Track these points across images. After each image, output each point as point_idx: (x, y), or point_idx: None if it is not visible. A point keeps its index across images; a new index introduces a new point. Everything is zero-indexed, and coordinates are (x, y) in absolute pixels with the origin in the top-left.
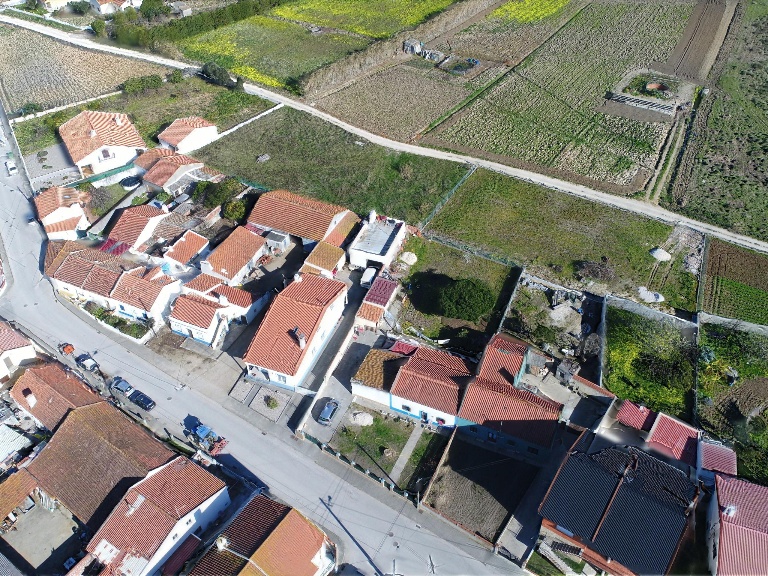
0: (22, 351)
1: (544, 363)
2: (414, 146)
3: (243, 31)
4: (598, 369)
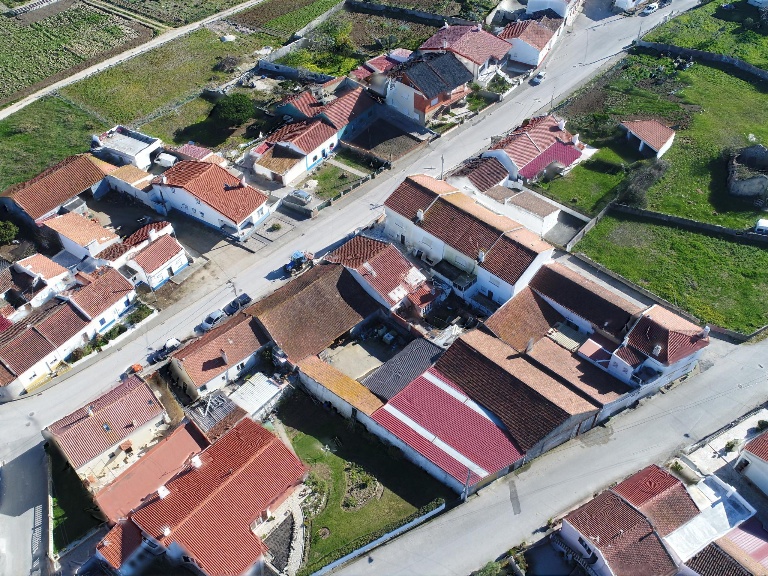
0: None
1: None
2: None
3: None
4: (318, 81)
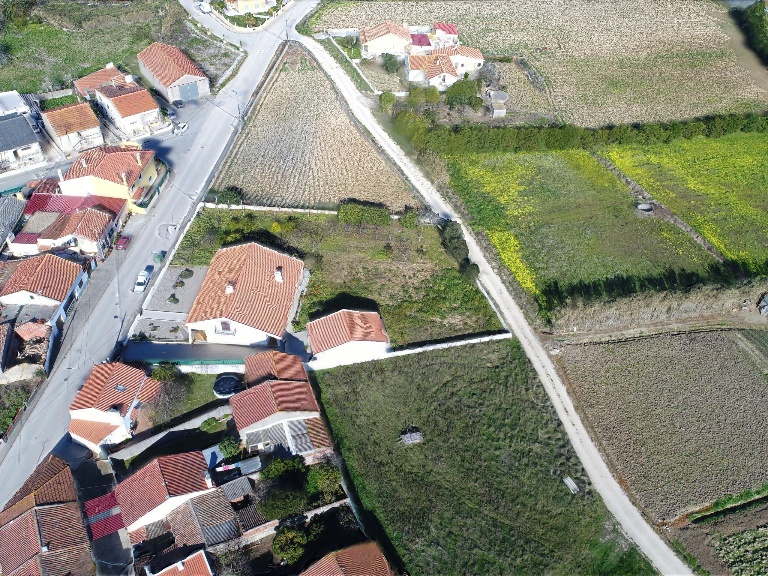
0: None
1: None
2: (661, 541)
3: (547, 169)
4: None
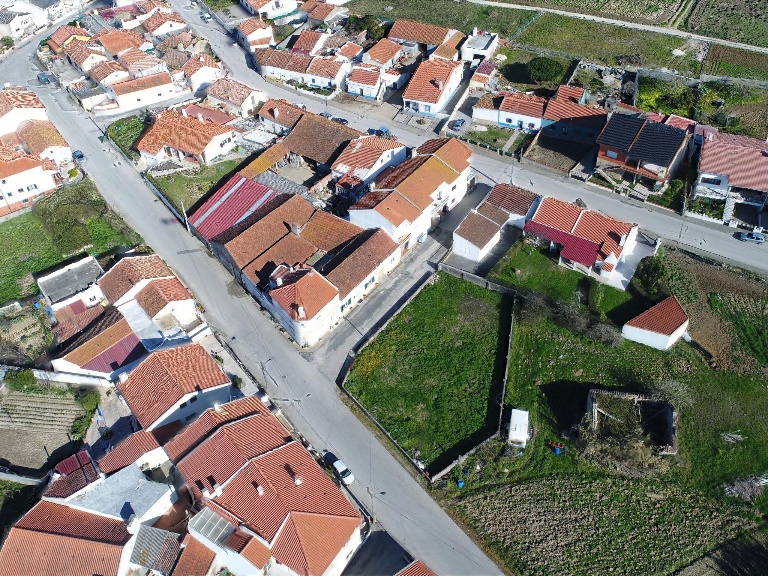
0: (260, 94)
1: (597, 100)
2: (497, 2)
3: None
4: None
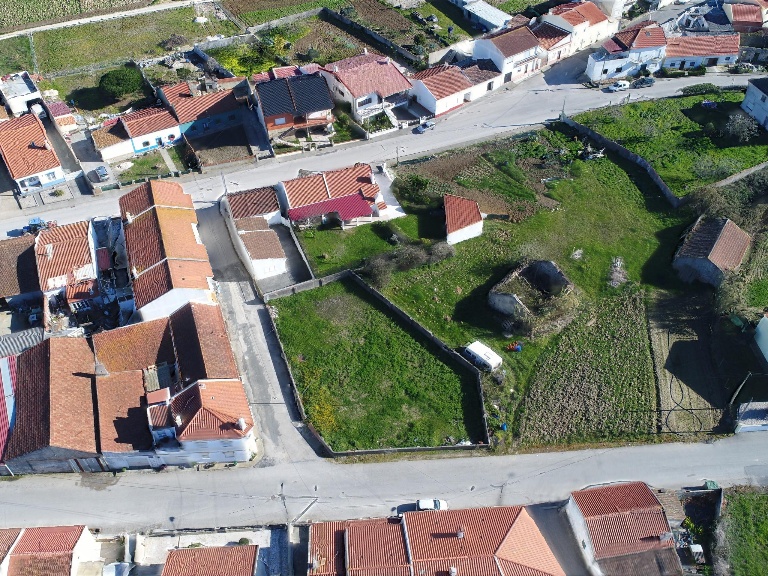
0: None
1: (196, 87)
2: None
3: None
4: (225, 76)
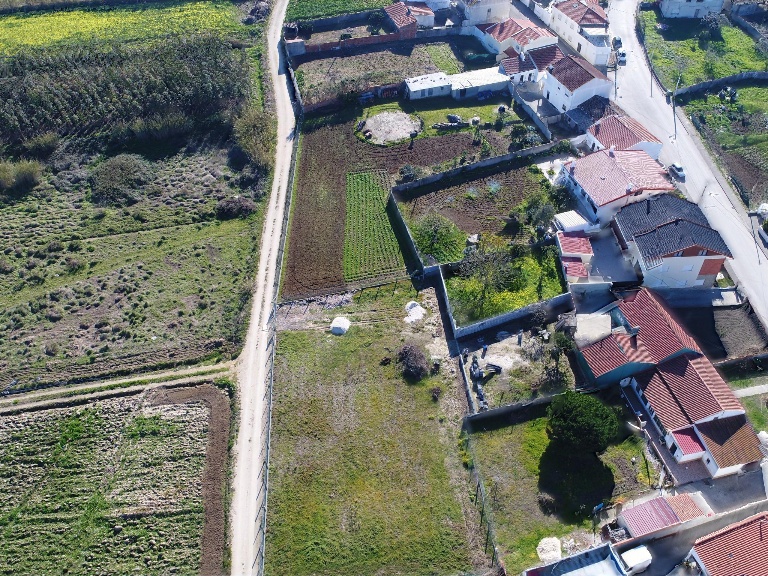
0: None
1: None
2: None
3: None
4: None
